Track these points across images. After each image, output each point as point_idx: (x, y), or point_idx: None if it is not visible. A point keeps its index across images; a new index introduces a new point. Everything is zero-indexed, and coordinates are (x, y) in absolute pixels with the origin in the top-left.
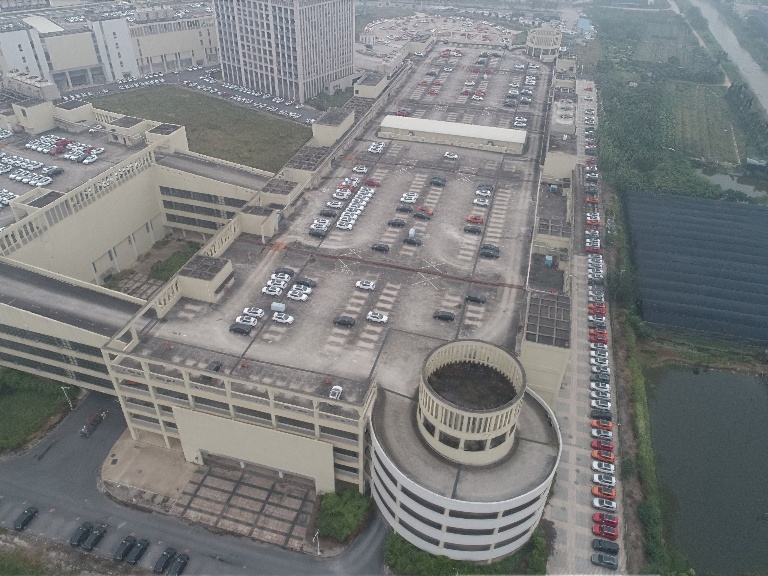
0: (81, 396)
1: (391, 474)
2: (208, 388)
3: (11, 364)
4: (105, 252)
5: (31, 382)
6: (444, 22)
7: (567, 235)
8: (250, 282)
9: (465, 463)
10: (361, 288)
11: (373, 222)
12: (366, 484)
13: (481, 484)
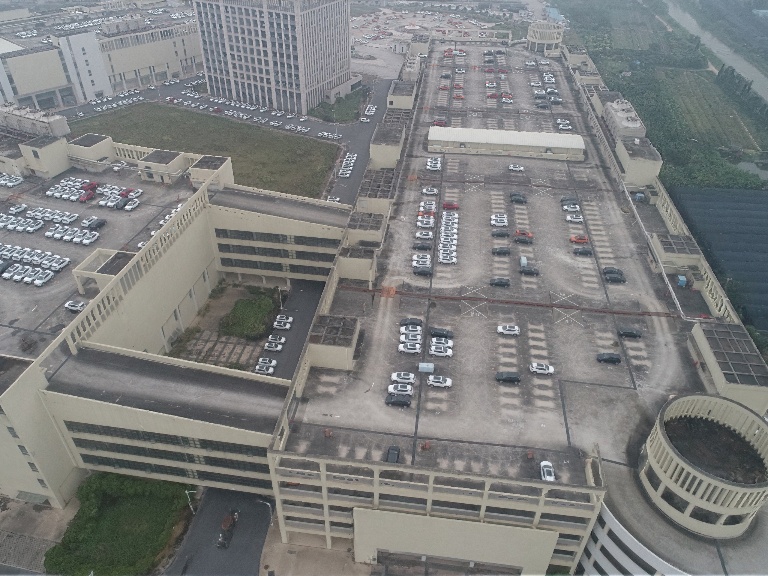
0: (199, 495)
1: (648, 563)
2: (403, 484)
3: (109, 468)
4: (171, 312)
5: (136, 486)
6: (414, 17)
7: (695, 252)
8: (378, 339)
9: (720, 537)
10: (504, 334)
11: (474, 252)
12: (578, 565)
13: (748, 561)
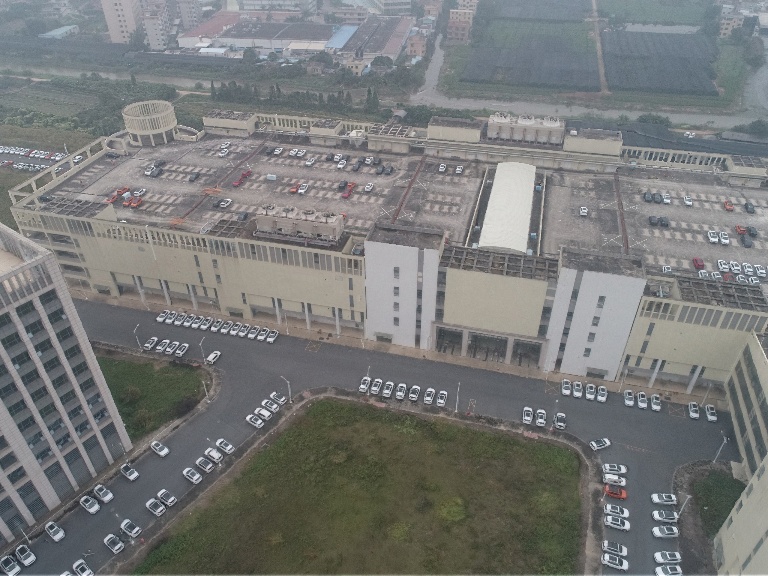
0: None
1: None
2: None
3: None
4: None
5: None
6: None
7: (755, 159)
8: None
9: None
10: None
11: None
12: None
13: None
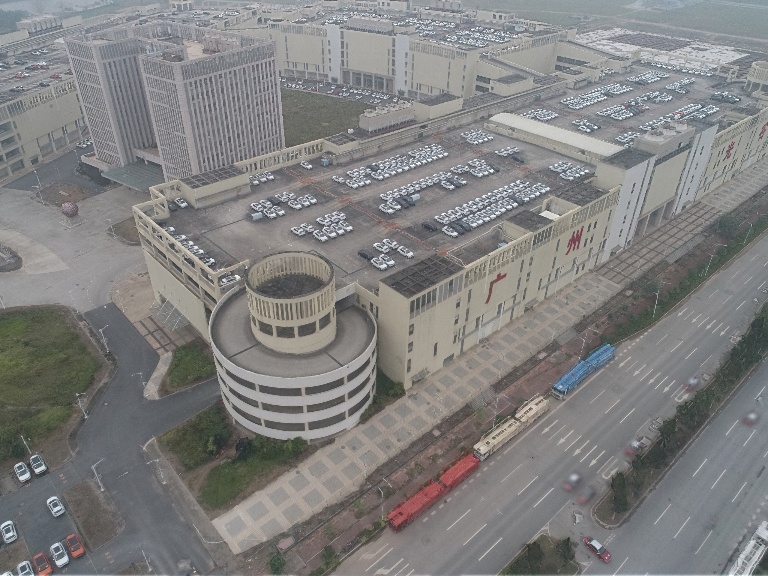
0: None
1: None
2: None
3: None
4: None
5: None
6: None
7: None
8: None
9: None
10: None
11: None
12: None
13: None
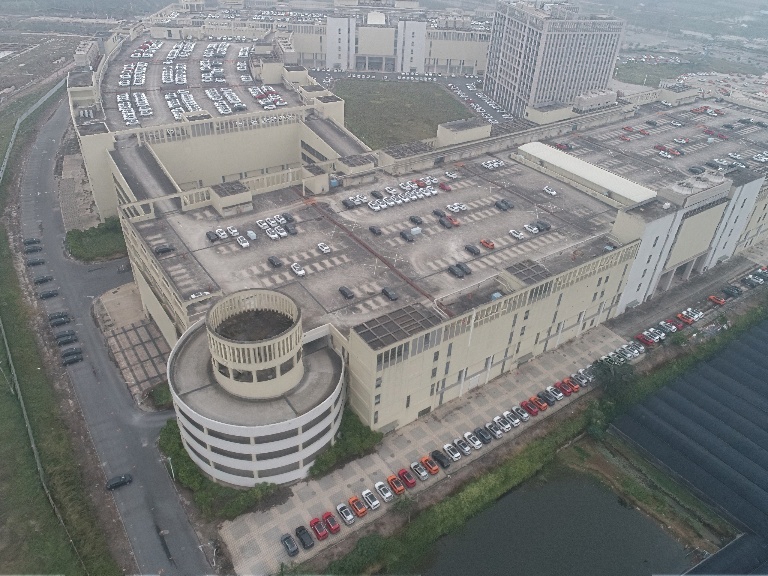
0: None
1: None
2: (145, 256)
3: None
4: (236, 173)
5: None
6: None
7: (530, 282)
8: (260, 214)
9: (220, 383)
10: (320, 249)
11: (402, 213)
12: None
13: (211, 401)
